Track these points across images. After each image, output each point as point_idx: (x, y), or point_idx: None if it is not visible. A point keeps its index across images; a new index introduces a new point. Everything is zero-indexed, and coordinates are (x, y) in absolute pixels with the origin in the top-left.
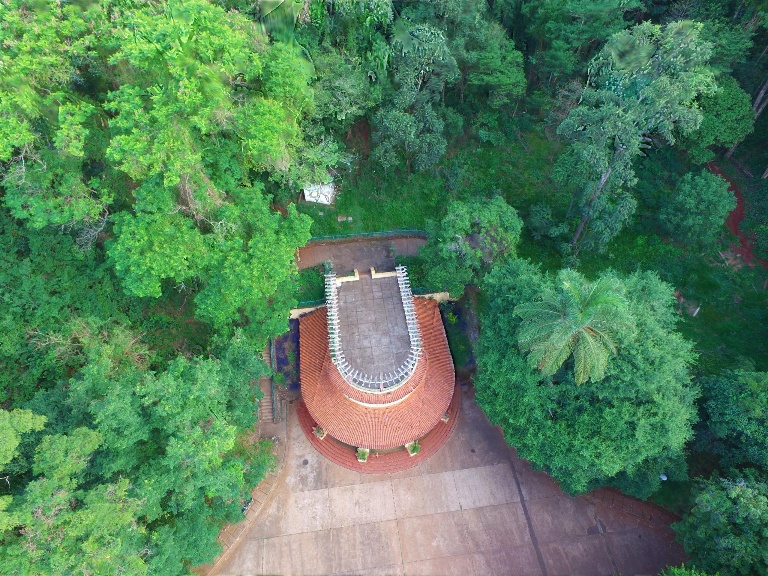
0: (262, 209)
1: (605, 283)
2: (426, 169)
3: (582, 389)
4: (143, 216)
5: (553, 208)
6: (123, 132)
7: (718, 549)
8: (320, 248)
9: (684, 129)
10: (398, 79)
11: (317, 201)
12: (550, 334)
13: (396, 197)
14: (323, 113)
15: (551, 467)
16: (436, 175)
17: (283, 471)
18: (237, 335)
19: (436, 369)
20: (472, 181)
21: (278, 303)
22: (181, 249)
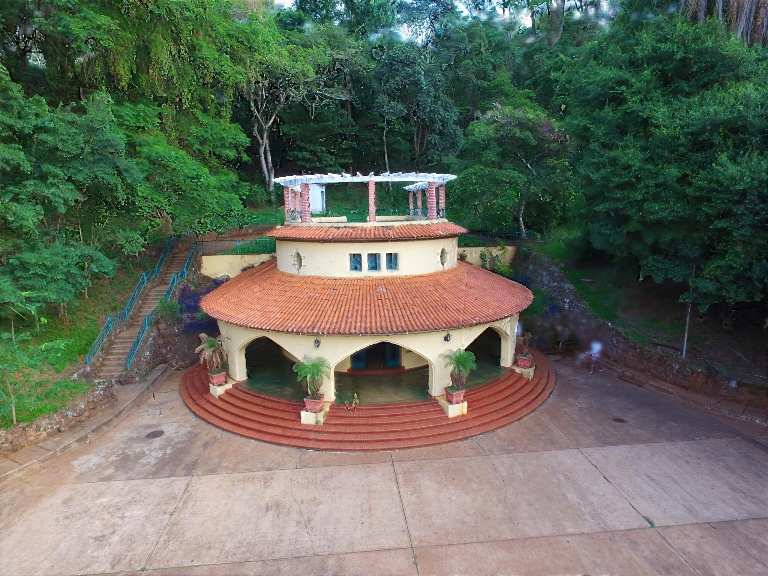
0: None
1: None
2: None
3: None
4: None
5: None
6: None
7: None
8: None
9: None
10: (404, 39)
11: (296, 98)
12: None
13: (405, 212)
14: None
15: None
16: None
17: (81, 446)
18: None
19: None
20: None
21: None
22: None
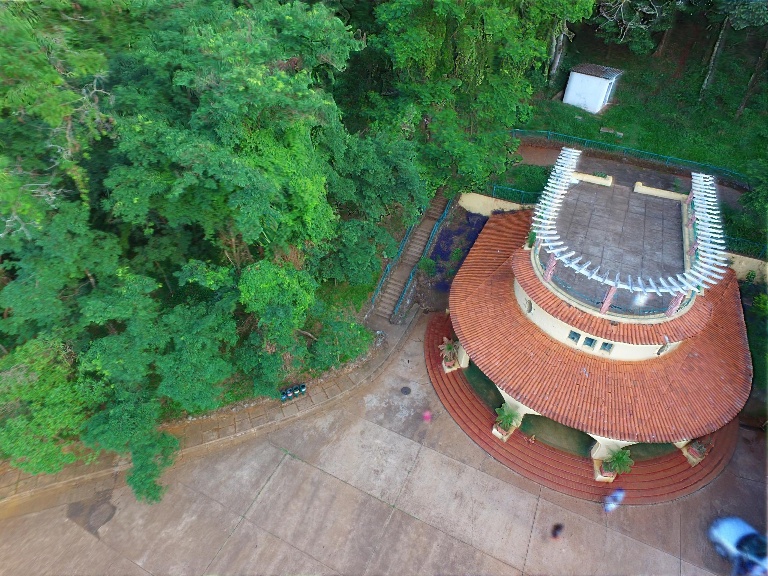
0: None
1: None
2: None
3: None
4: None
5: None
6: None
7: None
8: None
9: None
10: None
11: (607, 21)
12: None
13: (705, 131)
14: None
15: None
16: None
17: (368, 383)
18: None
19: (715, 352)
20: None
21: None
22: None
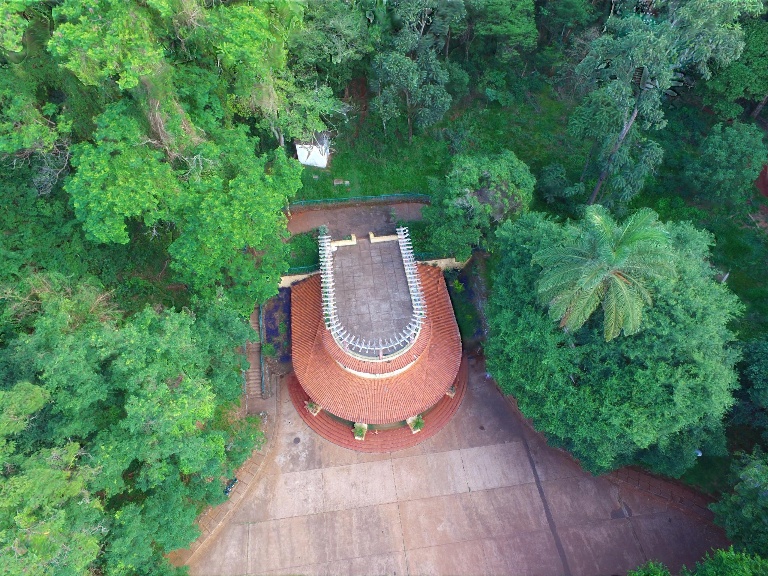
0: (246, 149)
1: (642, 217)
2: (429, 131)
3: (610, 349)
4: (104, 145)
5: (566, 170)
6: (68, 20)
7: (767, 531)
8: (314, 213)
9: (722, 59)
10: (399, 19)
11: None
12: (576, 281)
13: (397, 160)
14: (316, 57)
15: (573, 439)
16: (440, 137)
17: (272, 450)
18: (219, 294)
19: (441, 338)
20: (478, 143)
21: (267, 265)
22: (148, 182)
